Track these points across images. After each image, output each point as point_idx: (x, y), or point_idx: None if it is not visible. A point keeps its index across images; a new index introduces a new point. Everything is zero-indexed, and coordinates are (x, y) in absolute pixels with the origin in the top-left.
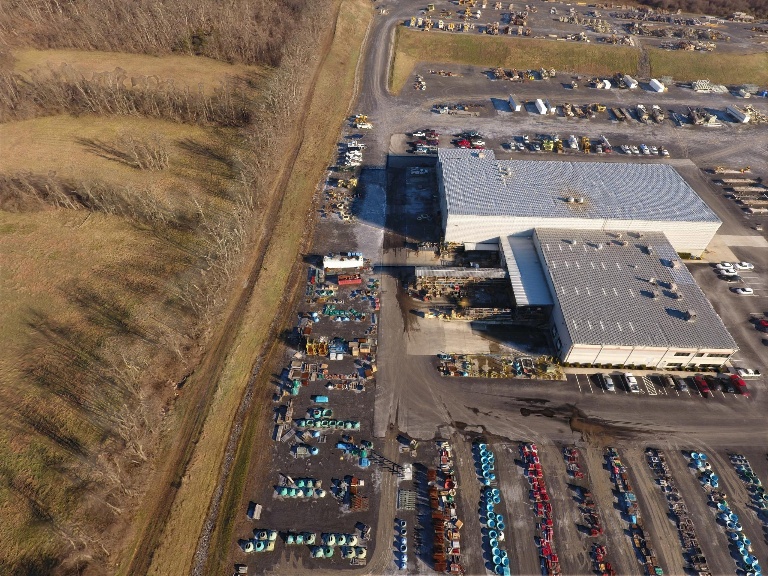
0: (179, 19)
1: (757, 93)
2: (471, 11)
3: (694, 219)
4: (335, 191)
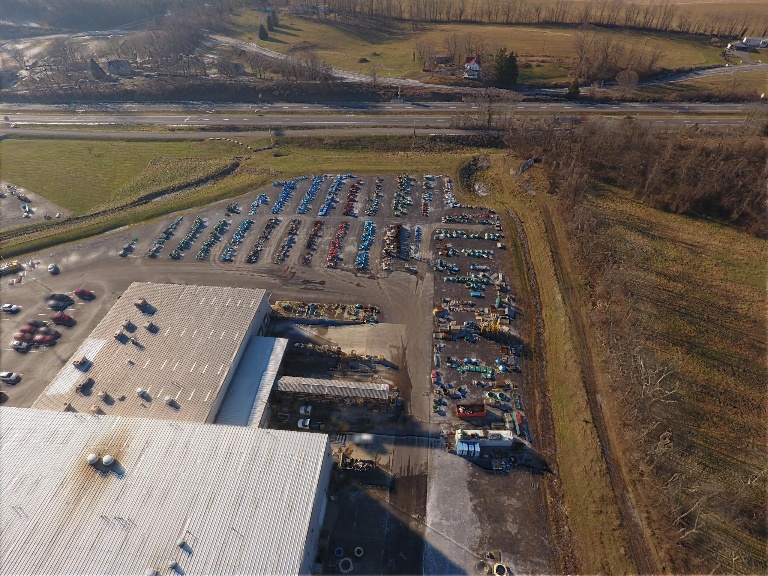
0: None
1: None
2: None
3: None
4: None
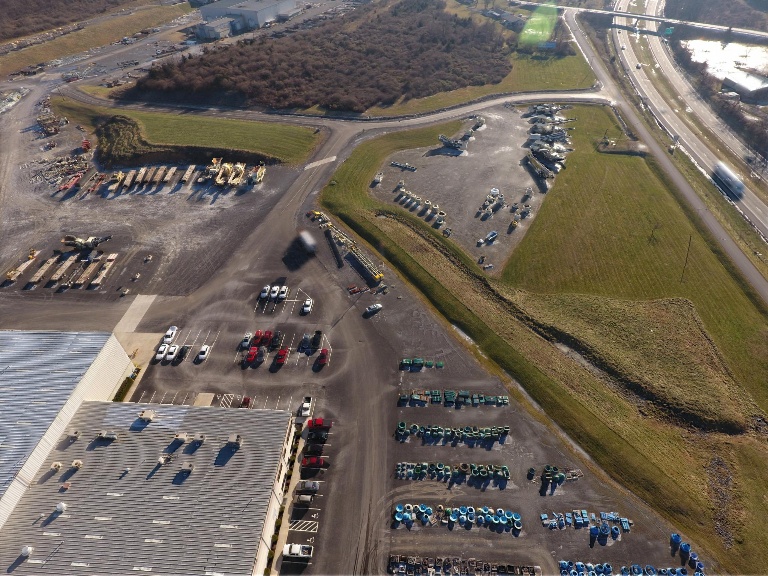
0: None
1: None
2: None
3: (89, 359)
4: None
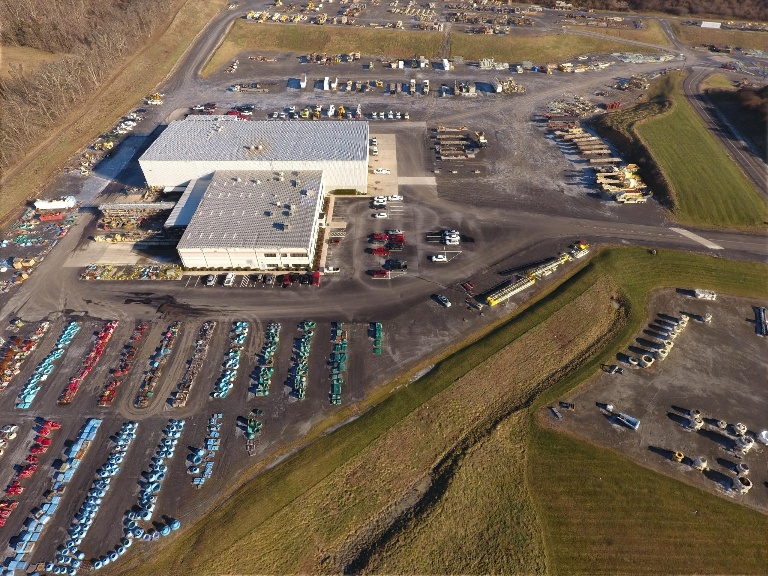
0: (3, 13)
1: (532, 69)
2: (316, 5)
3: (344, 158)
4: (91, 153)
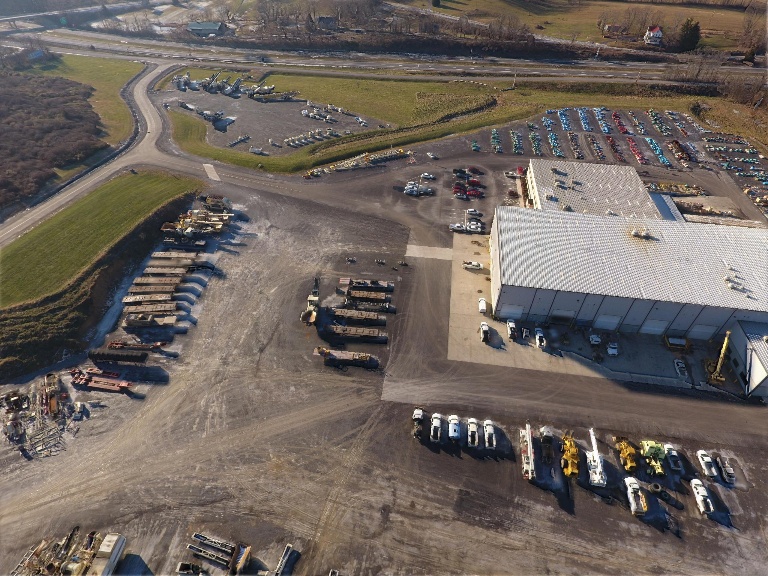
0: None
1: None
2: None
3: (523, 209)
4: None
